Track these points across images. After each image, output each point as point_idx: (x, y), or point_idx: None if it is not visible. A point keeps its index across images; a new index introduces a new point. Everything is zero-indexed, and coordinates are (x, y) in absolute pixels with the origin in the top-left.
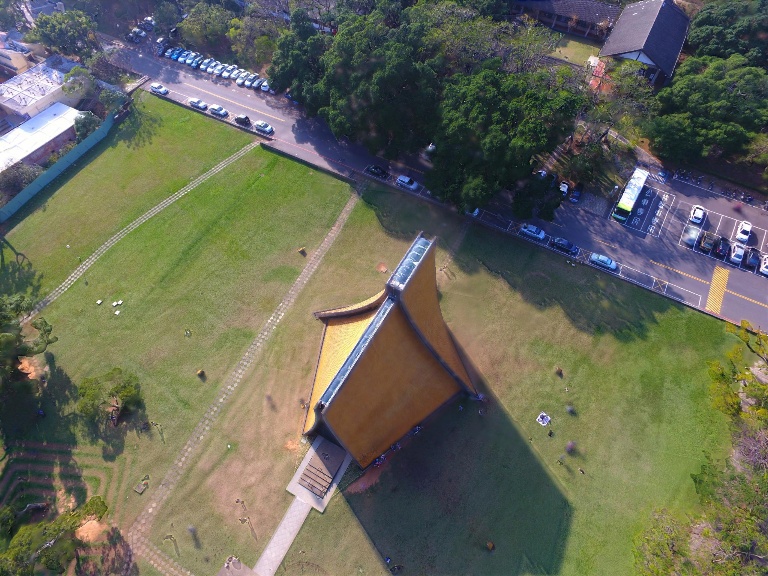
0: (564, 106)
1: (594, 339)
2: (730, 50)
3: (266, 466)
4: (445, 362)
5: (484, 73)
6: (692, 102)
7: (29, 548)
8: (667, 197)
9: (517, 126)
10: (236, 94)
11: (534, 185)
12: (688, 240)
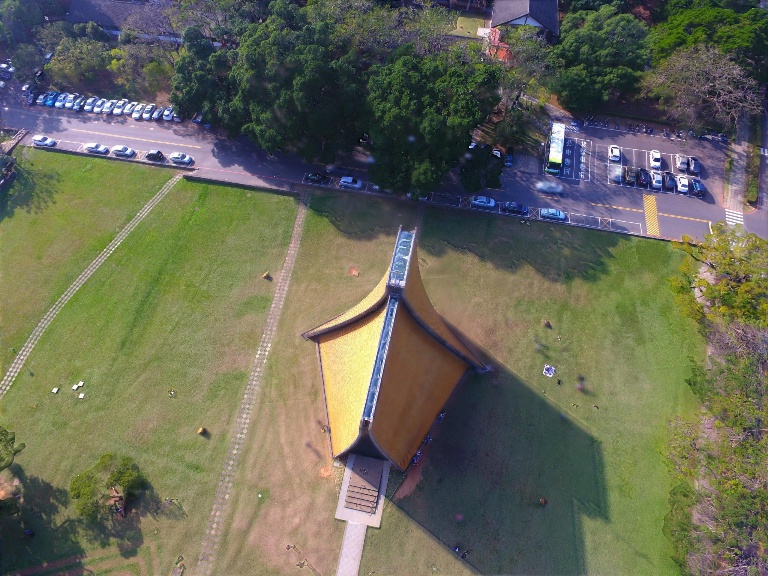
0: (486, 78)
1: (567, 286)
2: (598, 2)
3: (306, 502)
4: (451, 345)
5: (403, 60)
6: (583, 54)
7: None
8: (585, 143)
9: (447, 105)
10: (137, 130)
11: (476, 158)
12: (614, 178)
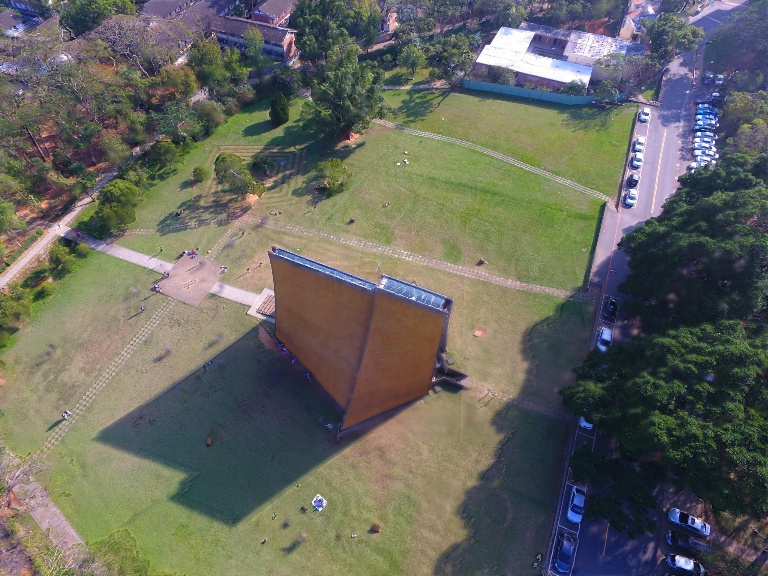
0: None
1: None
2: None
3: None
4: (357, 379)
5: None
6: None
7: (227, 161)
8: None
9: None
10: (673, 168)
11: (626, 476)
12: None
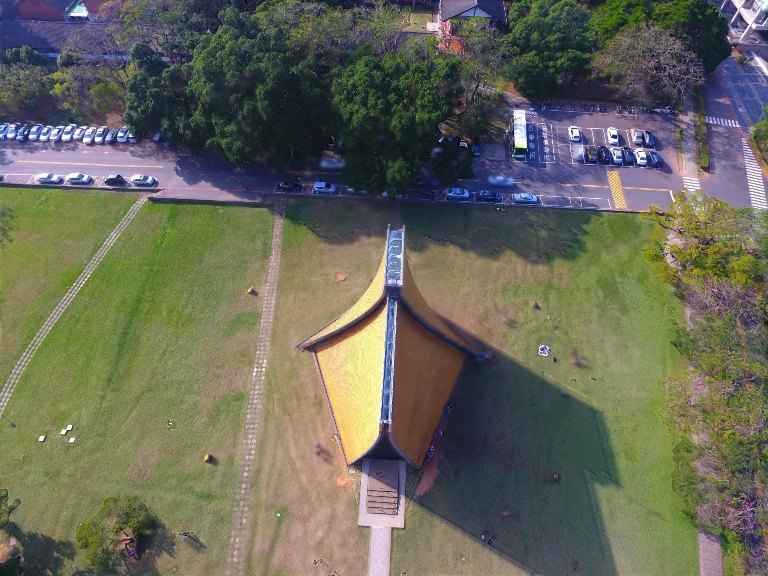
0: (448, 71)
1: (549, 266)
2: None
3: (327, 514)
4: (449, 337)
5: (364, 60)
6: (534, 41)
7: None
8: (546, 127)
9: (413, 101)
10: (90, 155)
11: (447, 151)
12: (578, 157)
